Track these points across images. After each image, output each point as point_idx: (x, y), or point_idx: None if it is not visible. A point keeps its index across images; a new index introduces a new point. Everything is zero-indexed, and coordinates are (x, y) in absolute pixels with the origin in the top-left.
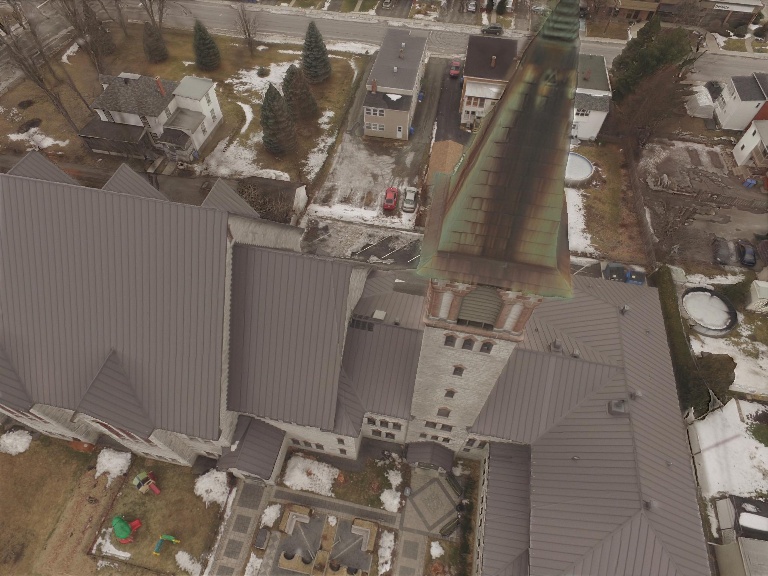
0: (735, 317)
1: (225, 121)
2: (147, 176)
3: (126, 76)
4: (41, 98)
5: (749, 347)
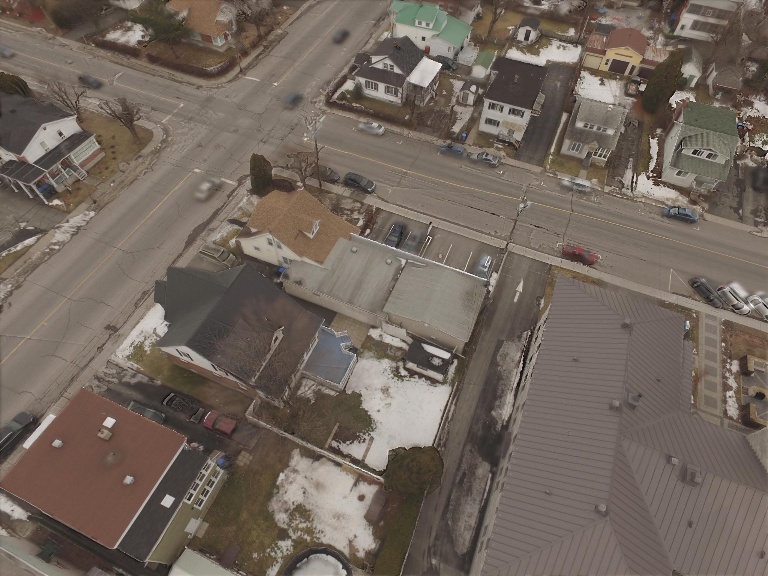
0: (291, 567)
1: None
2: None
3: None
4: None
5: (298, 522)
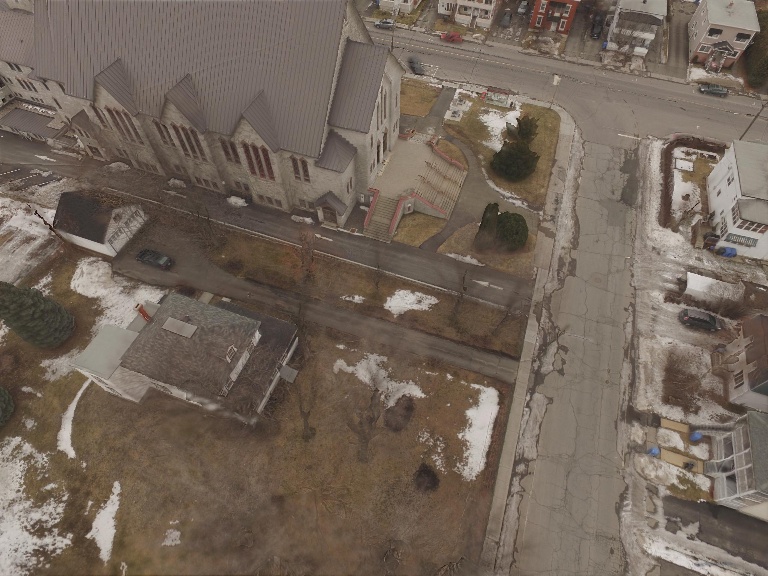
0: None
1: (109, 394)
2: (231, 294)
3: (184, 326)
4: (406, 499)
5: None
